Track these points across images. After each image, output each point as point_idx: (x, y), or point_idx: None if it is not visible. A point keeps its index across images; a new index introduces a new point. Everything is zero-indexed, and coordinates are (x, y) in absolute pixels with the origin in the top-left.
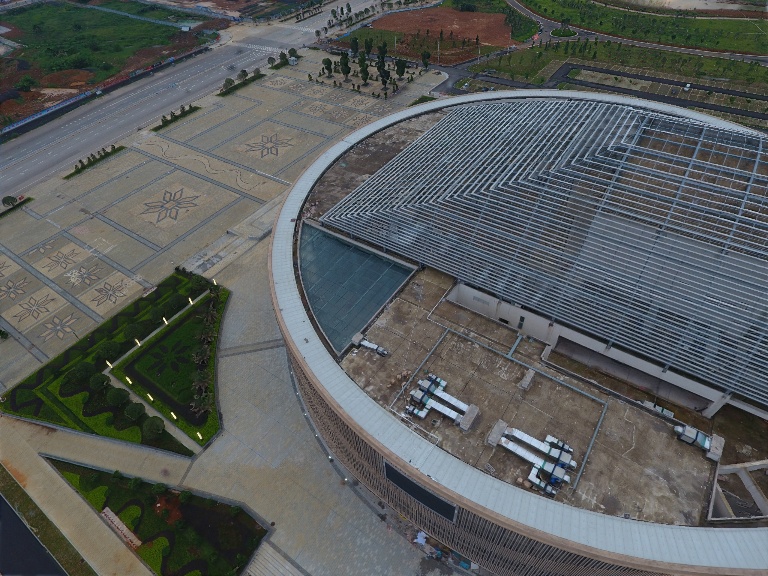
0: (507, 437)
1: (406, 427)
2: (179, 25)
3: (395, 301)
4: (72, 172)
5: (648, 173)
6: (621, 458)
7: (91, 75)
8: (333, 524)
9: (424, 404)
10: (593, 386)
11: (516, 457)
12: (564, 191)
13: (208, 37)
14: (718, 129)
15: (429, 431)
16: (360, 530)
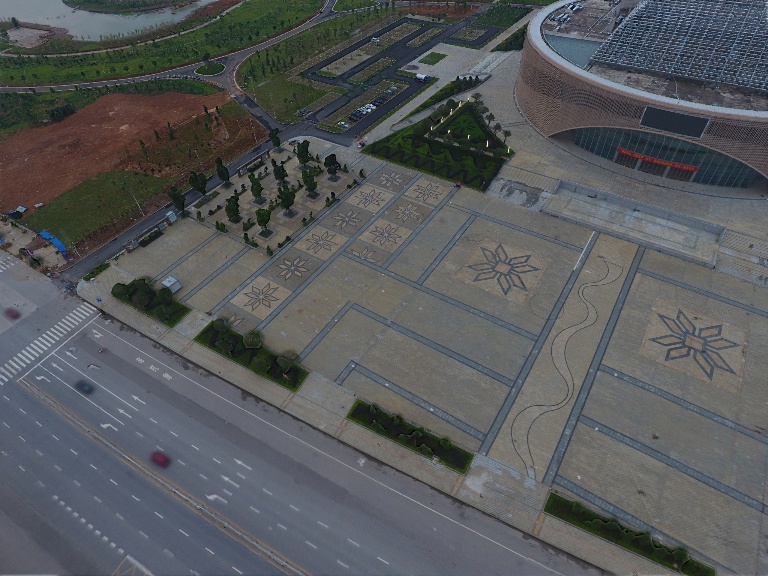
0: None
1: None
2: None
3: None
4: (686, 575)
5: None
6: None
7: None
8: None
9: None
10: None
11: None
12: None
13: None
14: None
15: None
16: None
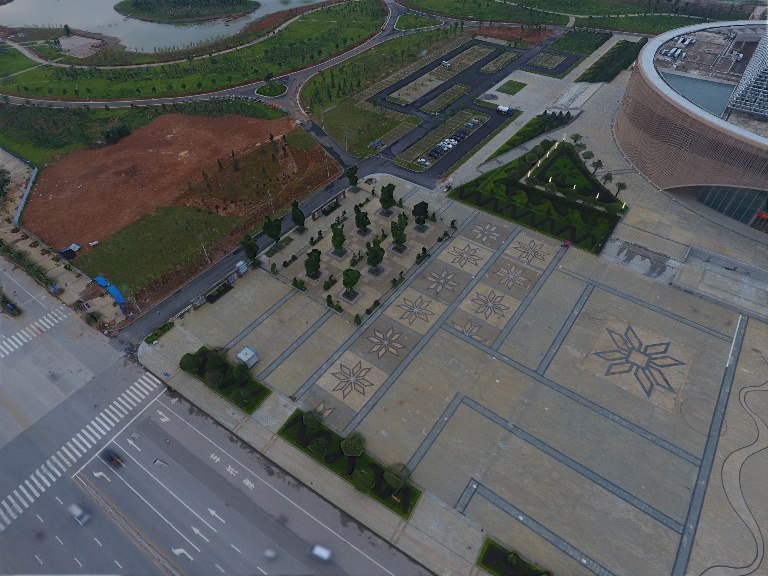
0: None
1: None
2: None
3: None
4: None
5: None
6: None
7: None
8: None
9: None
10: None
11: None
12: None
13: None
14: None
15: None
16: None
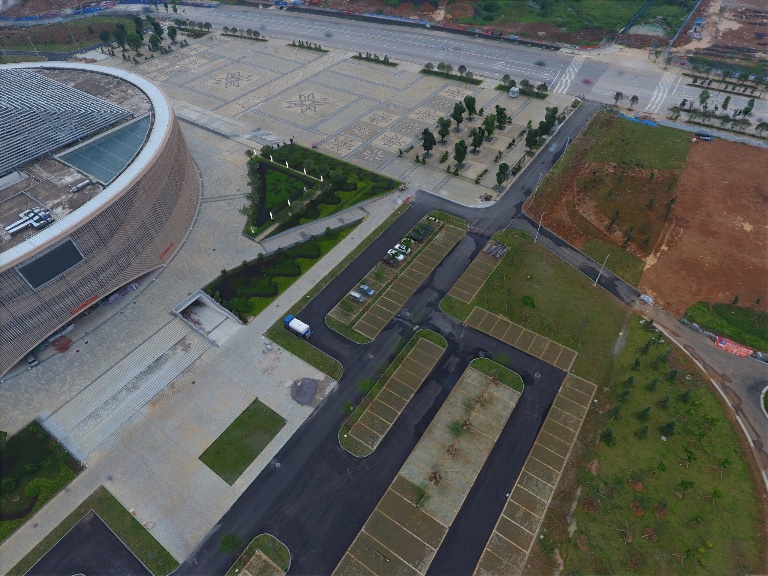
0: None
1: None
2: None
3: None
4: None
5: None
6: None
7: (468, 16)
8: None
9: None
10: None
11: None
12: None
13: (603, 45)
14: None
15: None
16: None
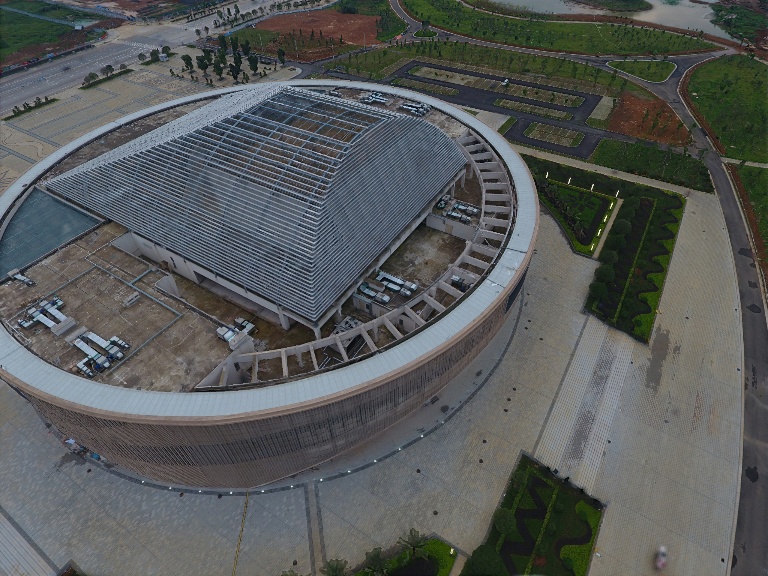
0: (82, 338)
1: (8, 334)
2: (74, 24)
3: (69, 246)
4: None
5: (246, 135)
6: (164, 351)
7: None
8: (4, 432)
9: (34, 318)
10: (182, 303)
11: (83, 353)
12: (188, 151)
13: (97, 35)
14: (332, 102)
15: (28, 337)
16: (25, 435)
